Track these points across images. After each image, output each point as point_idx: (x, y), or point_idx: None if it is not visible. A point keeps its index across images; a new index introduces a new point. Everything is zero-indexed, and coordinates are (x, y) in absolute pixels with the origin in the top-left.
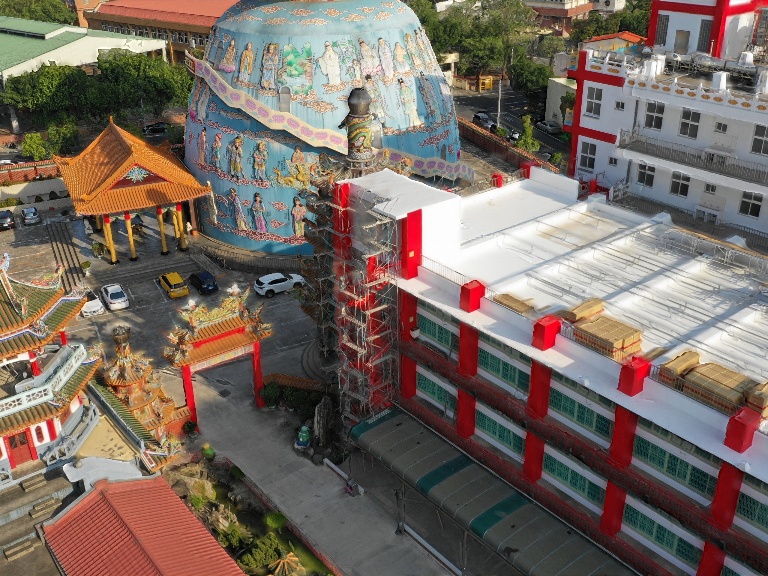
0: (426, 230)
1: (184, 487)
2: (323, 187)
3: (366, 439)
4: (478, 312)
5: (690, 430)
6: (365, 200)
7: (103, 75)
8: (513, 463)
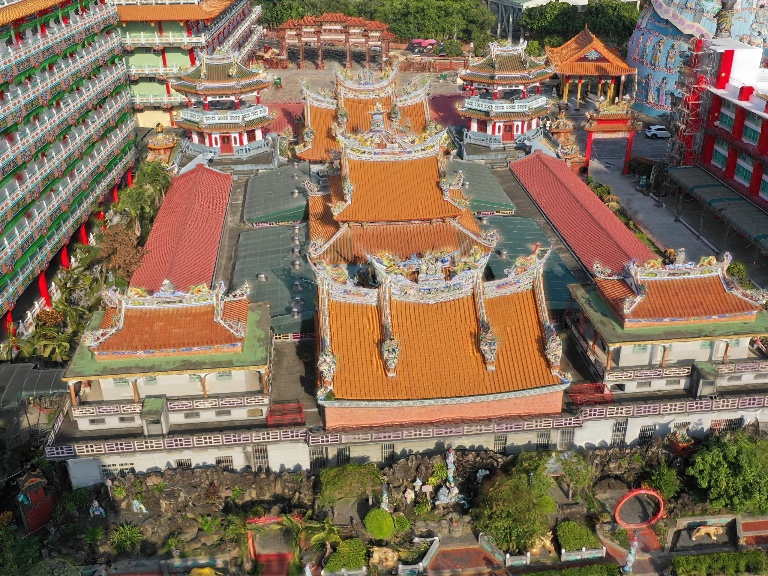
0: (735, 63)
1: None
2: None
3: (673, 172)
4: (746, 102)
5: None
6: (707, 45)
7: (589, 12)
8: None
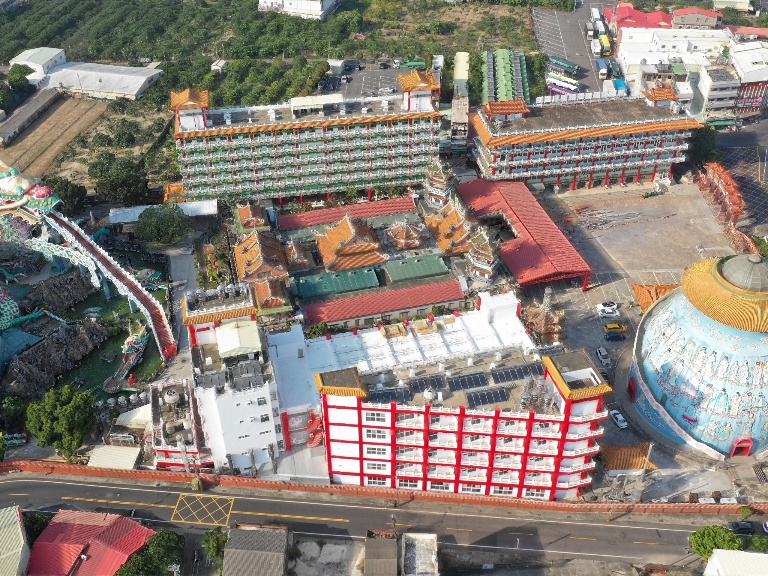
0: None
1: None
2: None
3: None
4: None
5: None
6: None
7: None
8: None
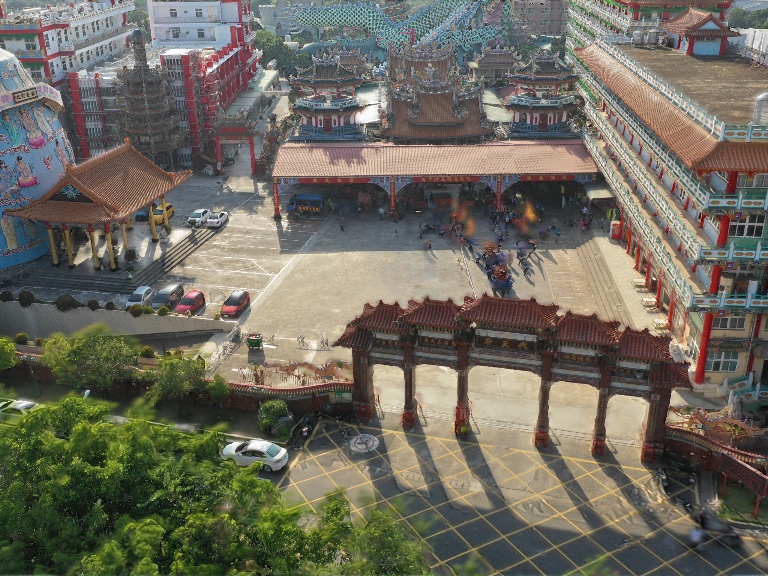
0: None
1: None
2: (162, 77)
3: None
4: None
5: None
6: None
7: None
8: None
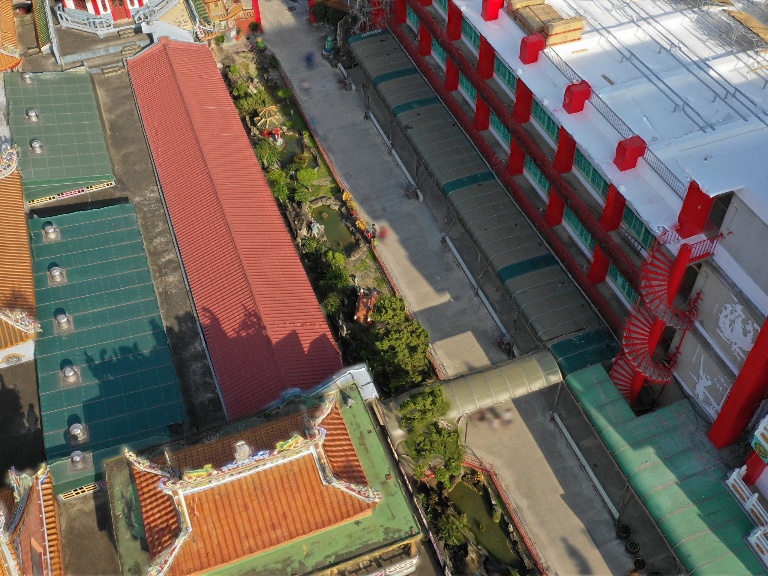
0: None
1: (231, 61)
2: None
3: (354, 46)
4: None
5: (506, 47)
6: None
7: None
8: (443, 77)
